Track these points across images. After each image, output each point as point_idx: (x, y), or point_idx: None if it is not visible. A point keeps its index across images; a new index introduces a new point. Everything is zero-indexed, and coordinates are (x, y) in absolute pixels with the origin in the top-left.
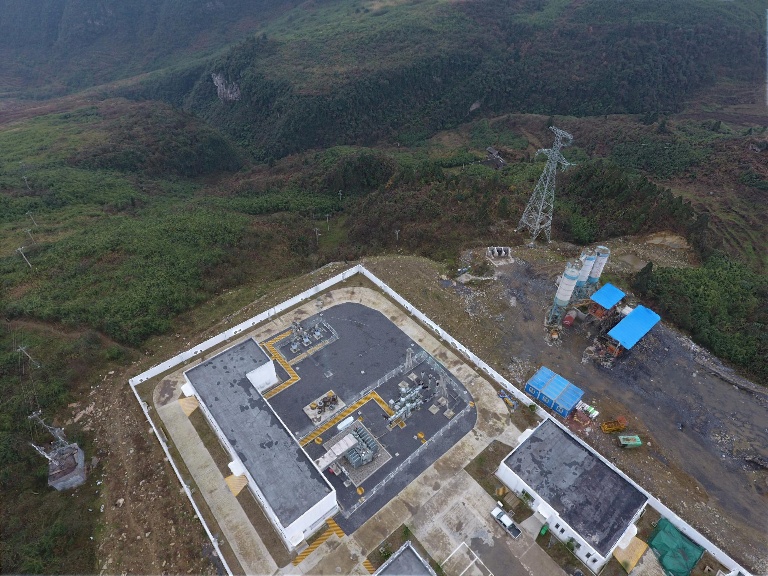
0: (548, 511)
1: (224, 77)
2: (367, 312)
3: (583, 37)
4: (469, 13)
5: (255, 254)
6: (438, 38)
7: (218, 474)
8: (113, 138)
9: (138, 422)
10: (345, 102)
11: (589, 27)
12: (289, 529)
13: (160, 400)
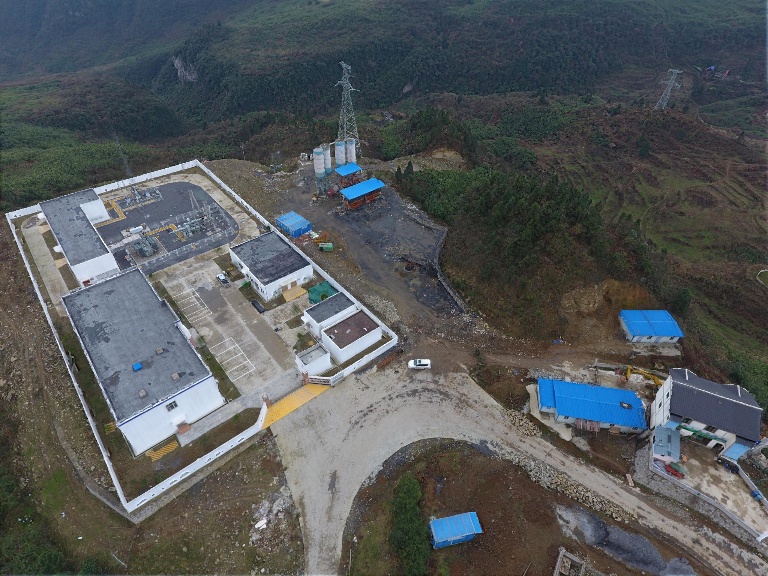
0: (246, 270)
1: (183, 60)
2: (191, 187)
3: (504, 27)
4: (405, 5)
5: (141, 168)
6: (374, 26)
7: (51, 259)
8: (66, 103)
9: (7, 236)
10: (284, 81)
11: (510, 18)
12: (75, 268)
13: (26, 226)
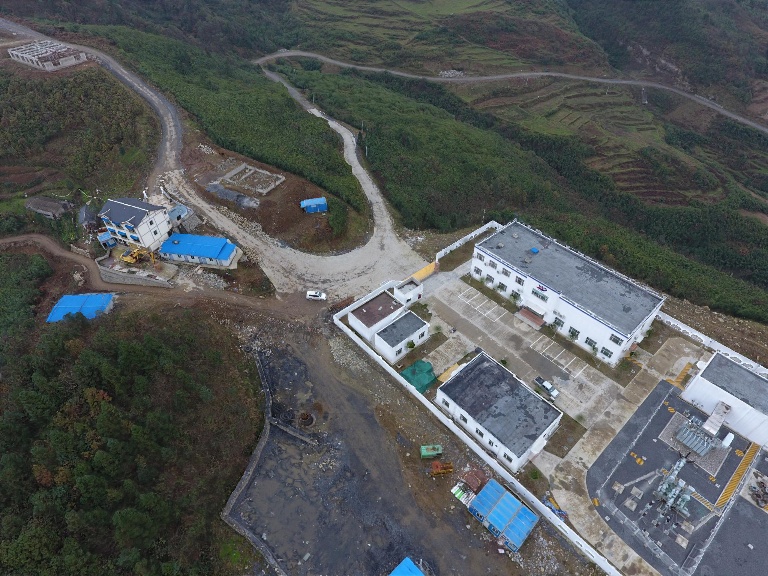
0: None
1: None
2: None
3: None
4: None
5: None
6: None
7: None
8: None
9: None
10: None
11: None
12: None
13: None
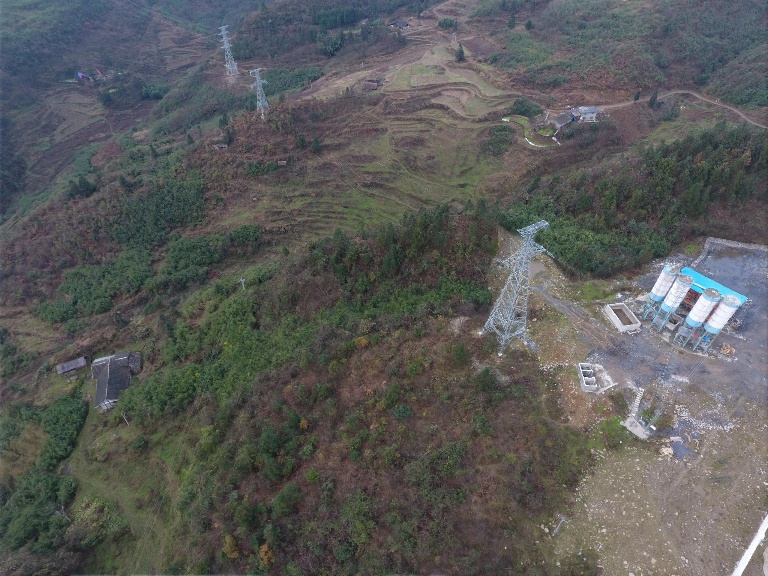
0: None
1: None
2: None
3: None
4: None
5: None
6: None
7: None
8: None
9: None
10: None
11: None
12: None
13: None
